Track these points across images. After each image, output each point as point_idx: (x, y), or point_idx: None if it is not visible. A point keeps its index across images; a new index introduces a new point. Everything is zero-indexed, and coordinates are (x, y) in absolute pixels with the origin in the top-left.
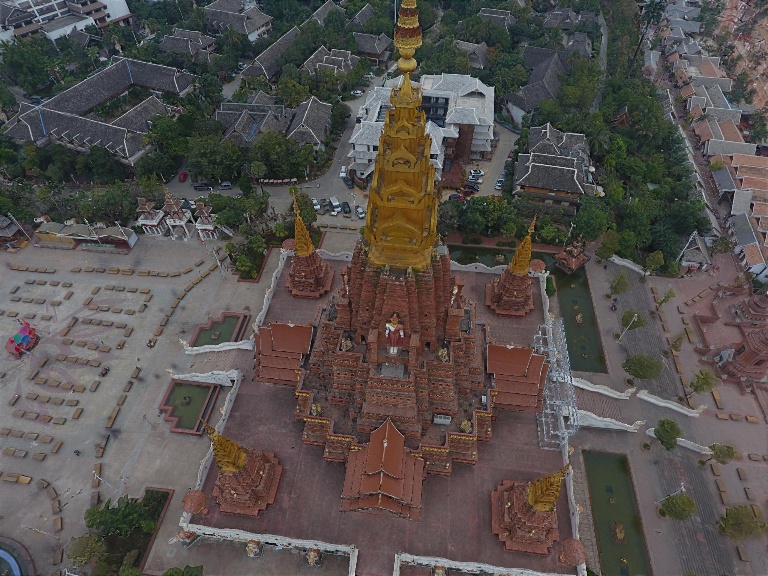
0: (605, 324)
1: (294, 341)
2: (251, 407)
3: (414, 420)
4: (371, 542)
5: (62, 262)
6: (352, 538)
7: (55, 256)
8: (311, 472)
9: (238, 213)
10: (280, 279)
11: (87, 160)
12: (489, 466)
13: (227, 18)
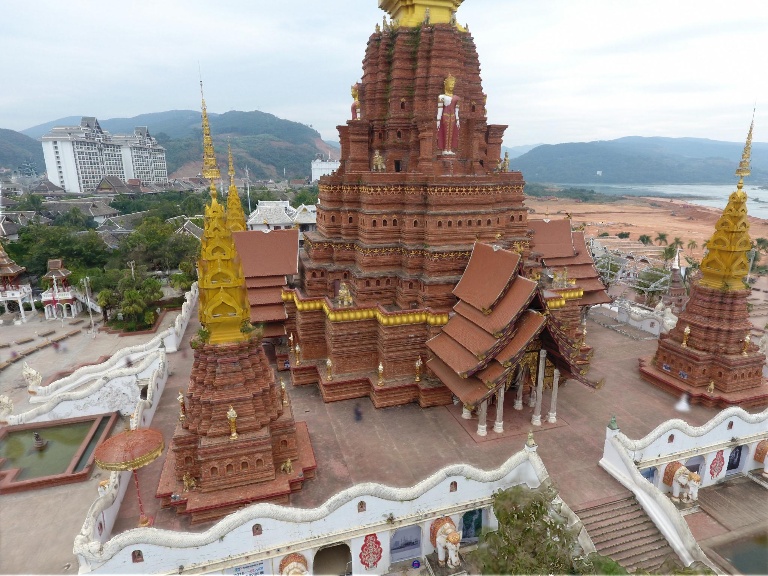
0: None
1: (271, 258)
2: None
3: None
4: None
5: None
6: None
7: None
8: (361, 425)
9: (112, 278)
10: (196, 307)
11: None
12: (606, 361)
13: (68, 207)
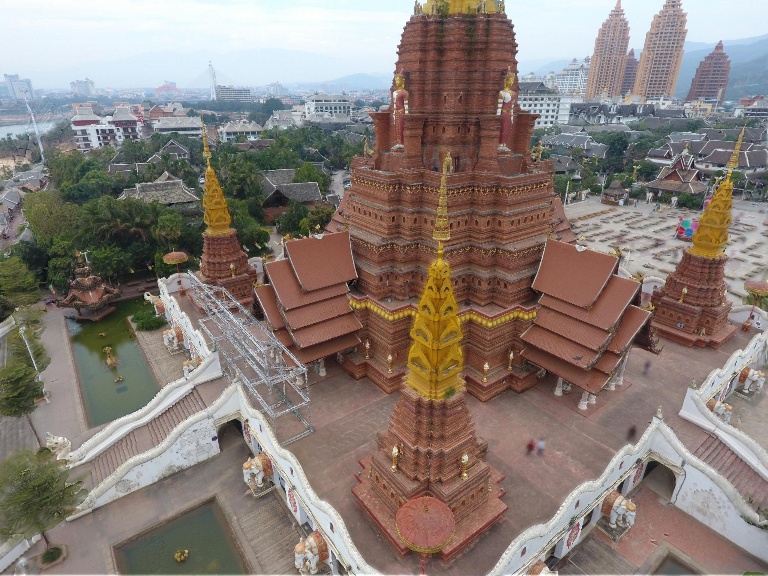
0: None
1: None
2: None
3: None
4: None
5: None
6: None
7: None
8: None
9: None
10: None
11: None
12: None
13: None
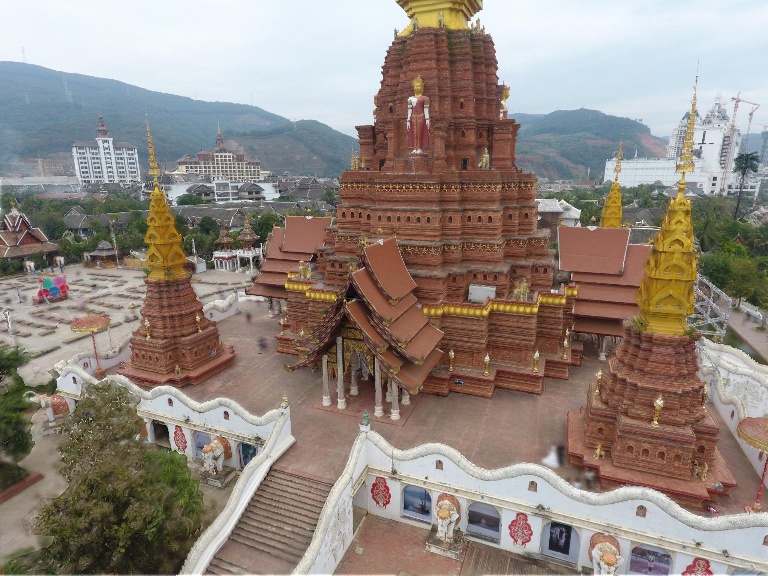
0: (763, 346)
1: (307, 239)
2: (232, 327)
3: (434, 257)
4: (323, 438)
5: (131, 274)
6: (292, 430)
7: (129, 272)
8: (270, 371)
9: None
10: None
11: (197, 229)
12: (567, 399)
13: None
